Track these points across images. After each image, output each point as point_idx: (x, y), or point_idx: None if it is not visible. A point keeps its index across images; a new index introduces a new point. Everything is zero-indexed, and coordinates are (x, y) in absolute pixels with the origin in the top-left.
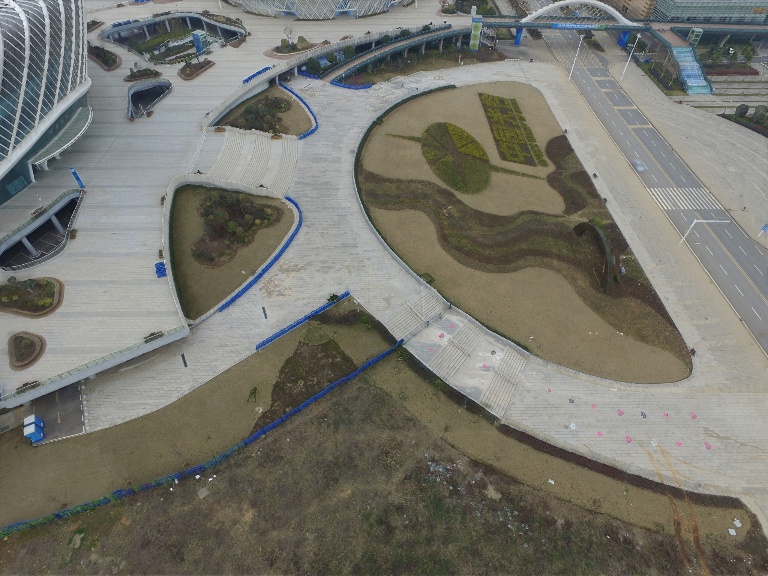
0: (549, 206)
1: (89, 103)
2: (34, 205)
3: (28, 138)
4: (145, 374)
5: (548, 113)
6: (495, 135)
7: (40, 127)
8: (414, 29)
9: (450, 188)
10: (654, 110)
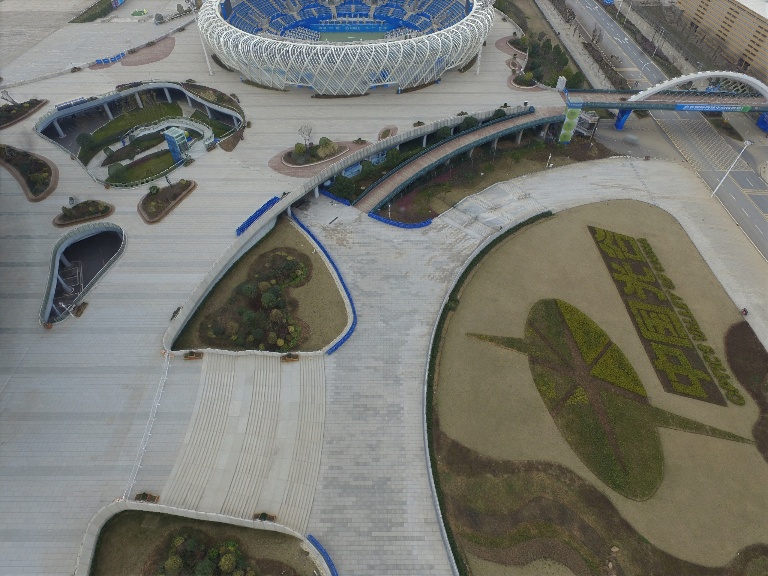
0: None
1: None
2: None
3: None
4: None
5: (703, 268)
6: (639, 327)
7: None
8: (482, 114)
9: (601, 483)
10: None
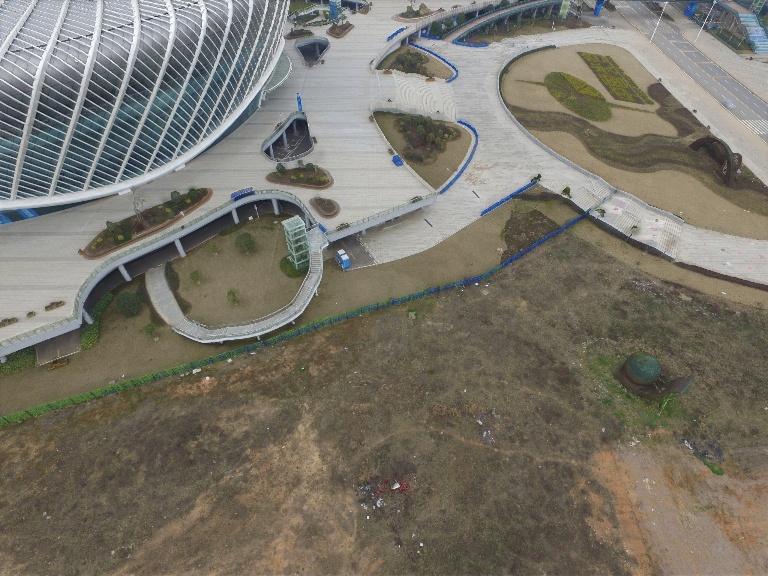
0: (665, 131)
1: None
2: (270, 122)
3: (269, 68)
4: (403, 231)
5: (640, 67)
6: (603, 82)
7: (274, 61)
8: None
9: (582, 117)
10: (730, 65)
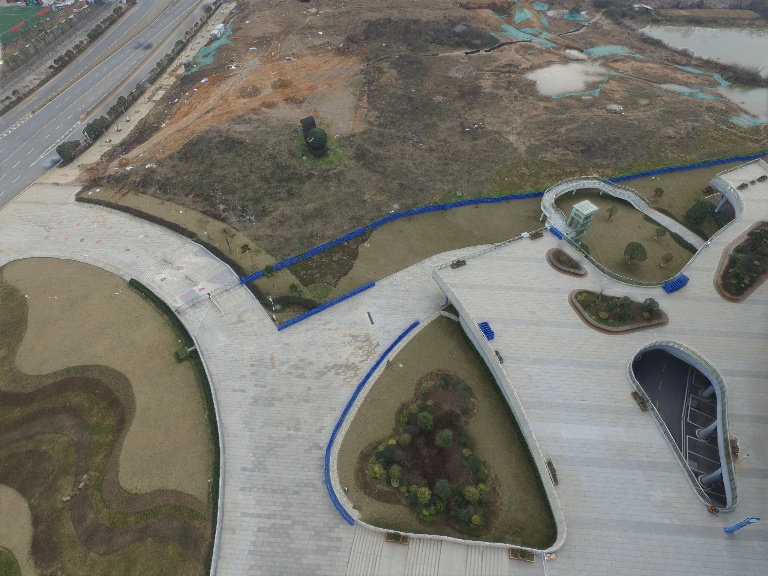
0: None
1: None
2: (767, 479)
3: None
4: None
5: None
6: None
7: None
8: None
9: (24, 569)
10: None
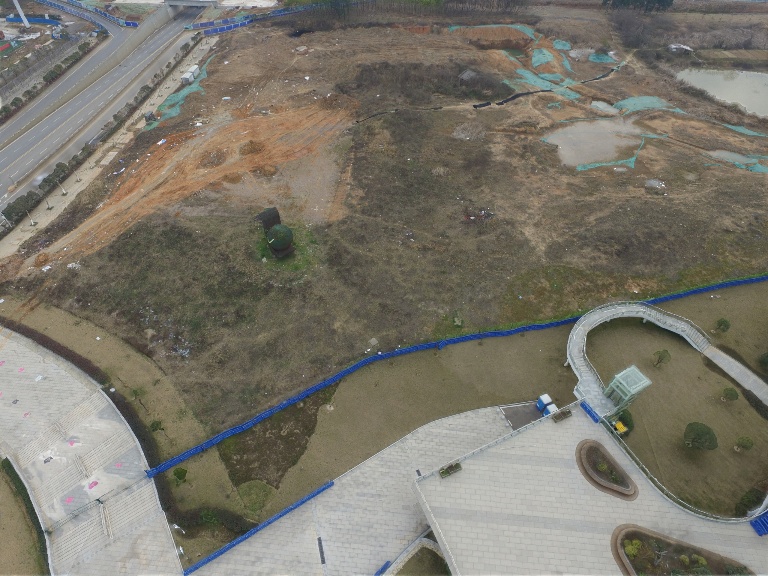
0: None
1: None
2: None
3: None
4: None
5: None
6: None
7: None
8: None
9: None
10: None
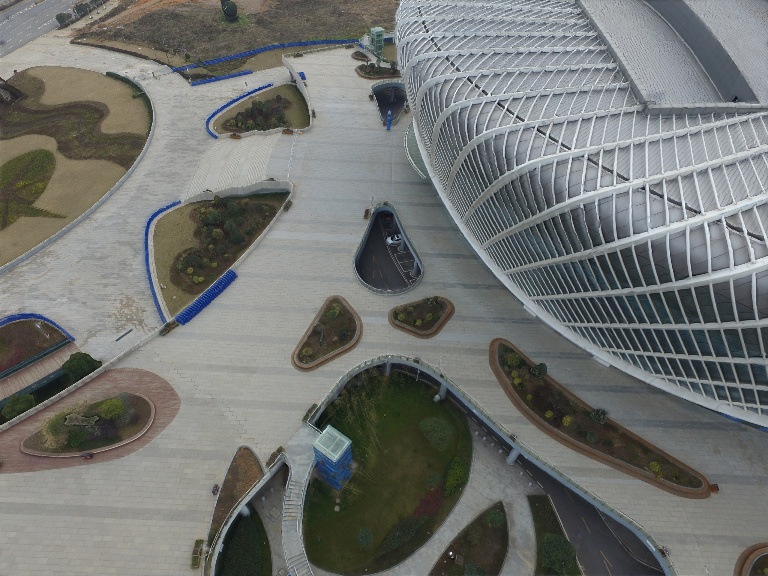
0: None
1: (467, 243)
2: None
3: None
4: None
5: None
6: None
7: None
8: None
9: (55, 153)
10: None
